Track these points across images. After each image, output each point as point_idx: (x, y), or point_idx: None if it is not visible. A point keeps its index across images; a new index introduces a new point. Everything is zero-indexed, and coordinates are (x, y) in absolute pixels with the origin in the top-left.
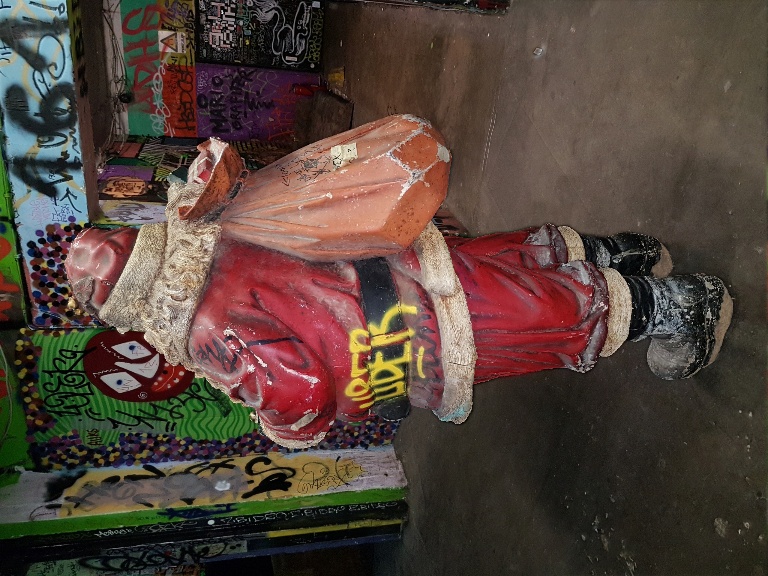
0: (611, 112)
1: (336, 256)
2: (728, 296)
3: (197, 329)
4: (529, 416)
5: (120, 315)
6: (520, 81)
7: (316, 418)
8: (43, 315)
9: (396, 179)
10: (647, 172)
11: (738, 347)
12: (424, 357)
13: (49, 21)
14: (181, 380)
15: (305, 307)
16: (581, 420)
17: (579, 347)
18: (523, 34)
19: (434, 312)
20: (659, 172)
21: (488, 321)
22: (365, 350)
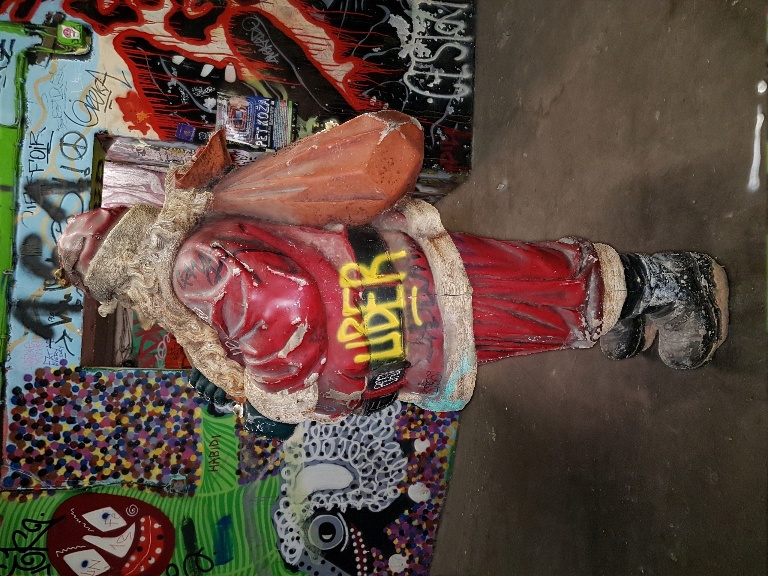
0: (571, 192)
1: (323, 209)
2: (717, 264)
3: (183, 253)
4: (560, 522)
5: (106, 270)
6: (490, 217)
7: (306, 340)
8: (13, 474)
9: (374, 130)
10: (614, 218)
11: (745, 311)
12: (418, 297)
13: (75, 181)
14: (157, 560)
15: (293, 247)
16: (616, 488)
17: (578, 297)
18: (486, 182)
19: (423, 253)
20: (624, 210)
21: (479, 269)
22: (356, 286)
